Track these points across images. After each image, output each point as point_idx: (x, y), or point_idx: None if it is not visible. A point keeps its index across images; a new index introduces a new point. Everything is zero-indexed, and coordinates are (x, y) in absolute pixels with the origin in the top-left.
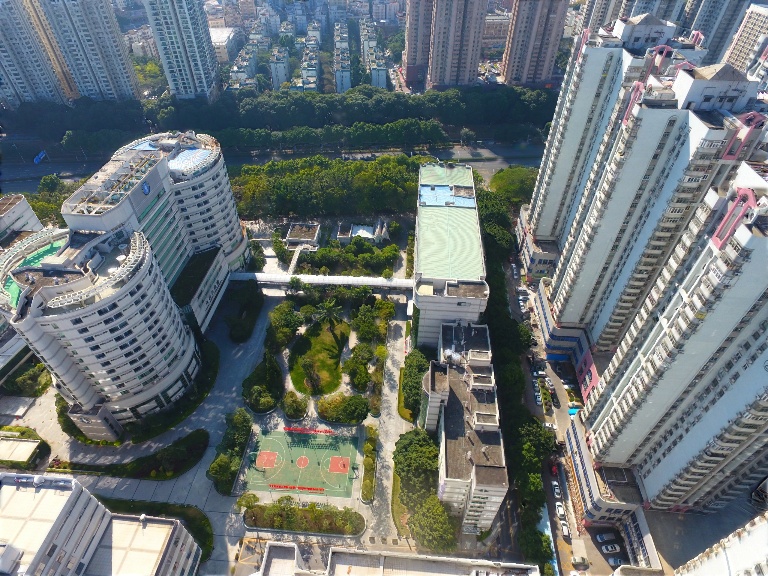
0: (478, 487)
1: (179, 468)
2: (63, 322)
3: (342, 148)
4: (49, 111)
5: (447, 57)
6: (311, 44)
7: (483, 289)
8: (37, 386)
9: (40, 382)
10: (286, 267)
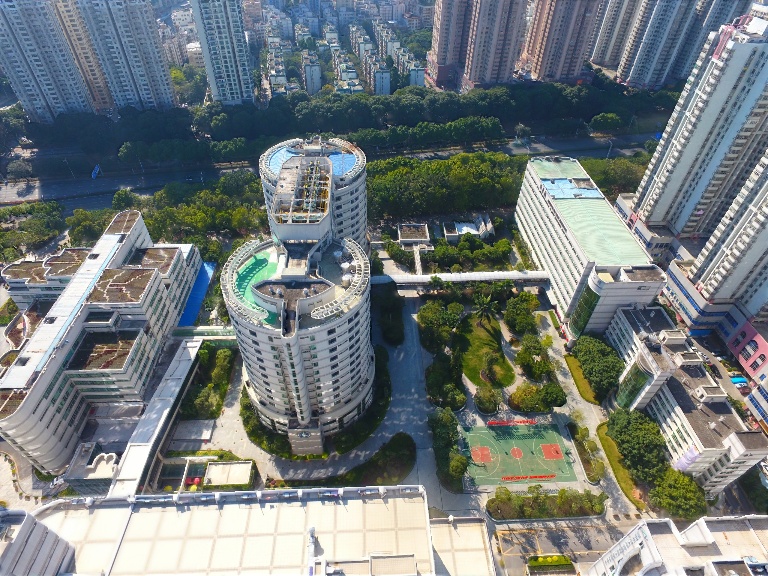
0: (746, 452)
1: (401, 472)
2: (321, 333)
3: (403, 149)
4: (91, 123)
5: (489, 56)
6: (335, 46)
7: (657, 273)
8: (211, 407)
9: (212, 403)
10: (406, 268)
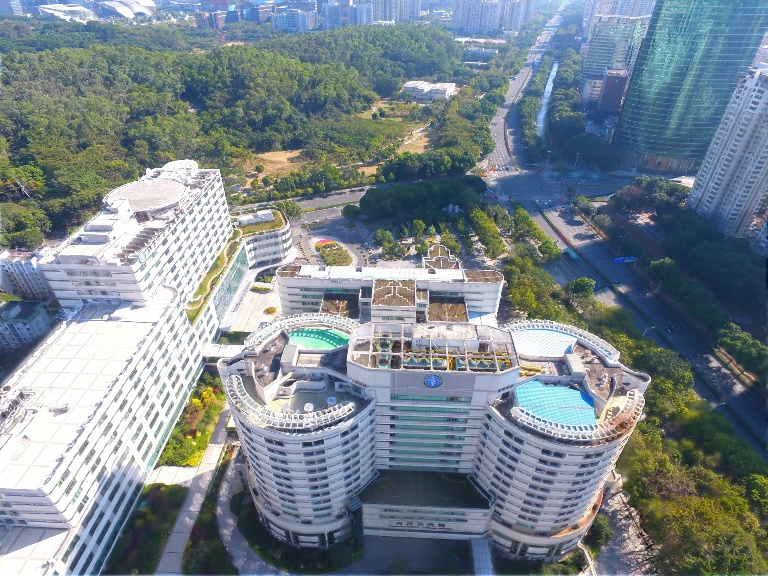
0: None
1: None
2: None
3: None
4: (697, 230)
5: None
6: None
7: None
8: None
9: None
10: None
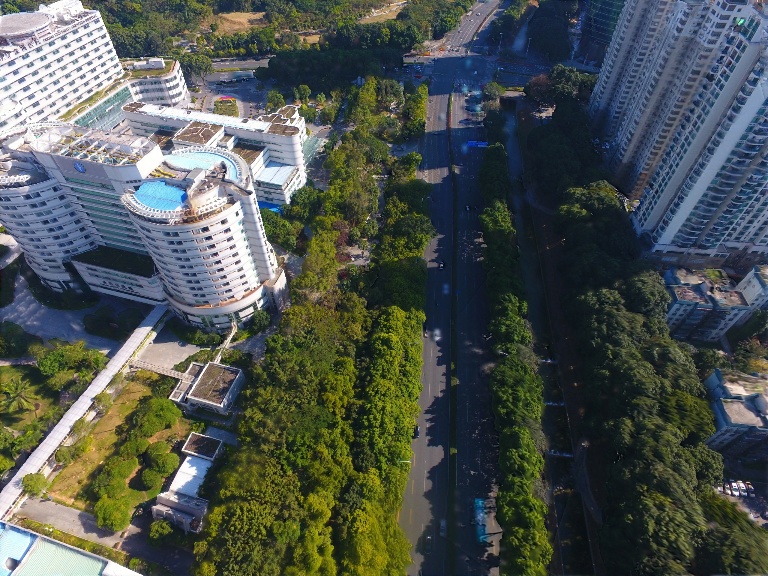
0: None
1: None
2: None
3: None
4: (562, 123)
5: None
6: None
7: None
8: None
9: None
10: None
